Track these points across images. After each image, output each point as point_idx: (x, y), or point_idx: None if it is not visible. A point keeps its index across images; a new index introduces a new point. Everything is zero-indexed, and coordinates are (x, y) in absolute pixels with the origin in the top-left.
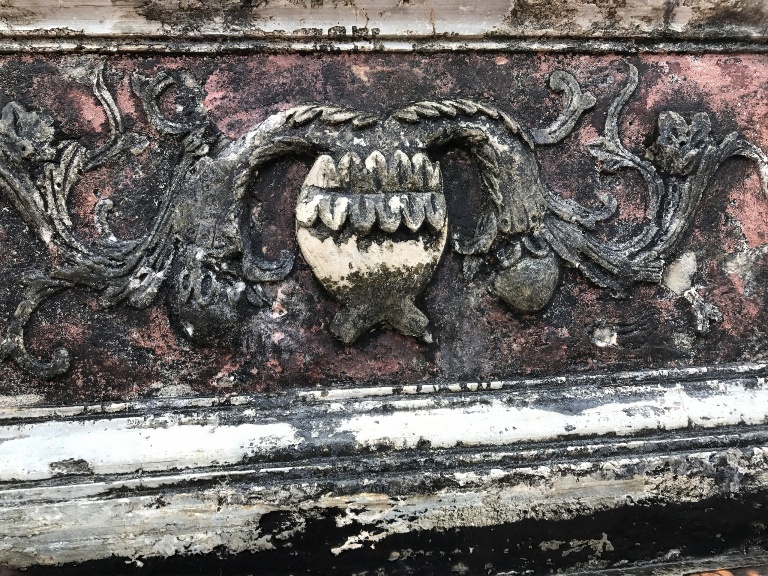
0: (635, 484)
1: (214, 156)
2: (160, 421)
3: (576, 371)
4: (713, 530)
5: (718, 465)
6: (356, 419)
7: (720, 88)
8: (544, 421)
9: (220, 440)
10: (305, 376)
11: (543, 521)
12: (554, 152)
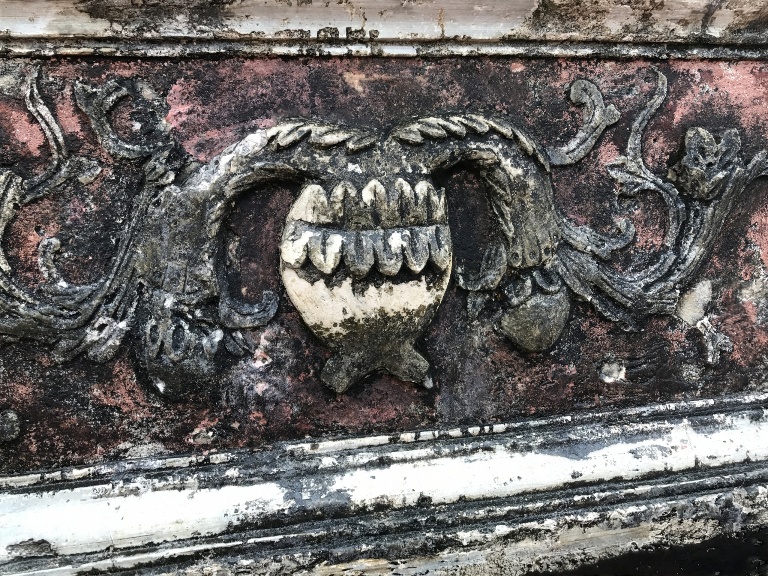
0: (641, 531)
1: (181, 183)
2: (130, 488)
3: (582, 409)
4: (713, 569)
5: (723, 507)
6: (350, 474)
7: (752, 100)
8: (550, 468)
9: (201, 508)
10: (292, 428)
11: (547, 573)
12: (570, 173)
